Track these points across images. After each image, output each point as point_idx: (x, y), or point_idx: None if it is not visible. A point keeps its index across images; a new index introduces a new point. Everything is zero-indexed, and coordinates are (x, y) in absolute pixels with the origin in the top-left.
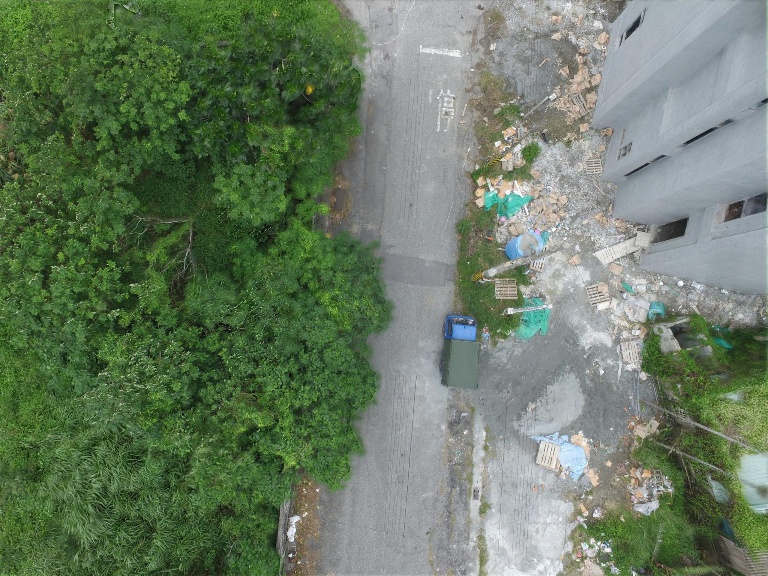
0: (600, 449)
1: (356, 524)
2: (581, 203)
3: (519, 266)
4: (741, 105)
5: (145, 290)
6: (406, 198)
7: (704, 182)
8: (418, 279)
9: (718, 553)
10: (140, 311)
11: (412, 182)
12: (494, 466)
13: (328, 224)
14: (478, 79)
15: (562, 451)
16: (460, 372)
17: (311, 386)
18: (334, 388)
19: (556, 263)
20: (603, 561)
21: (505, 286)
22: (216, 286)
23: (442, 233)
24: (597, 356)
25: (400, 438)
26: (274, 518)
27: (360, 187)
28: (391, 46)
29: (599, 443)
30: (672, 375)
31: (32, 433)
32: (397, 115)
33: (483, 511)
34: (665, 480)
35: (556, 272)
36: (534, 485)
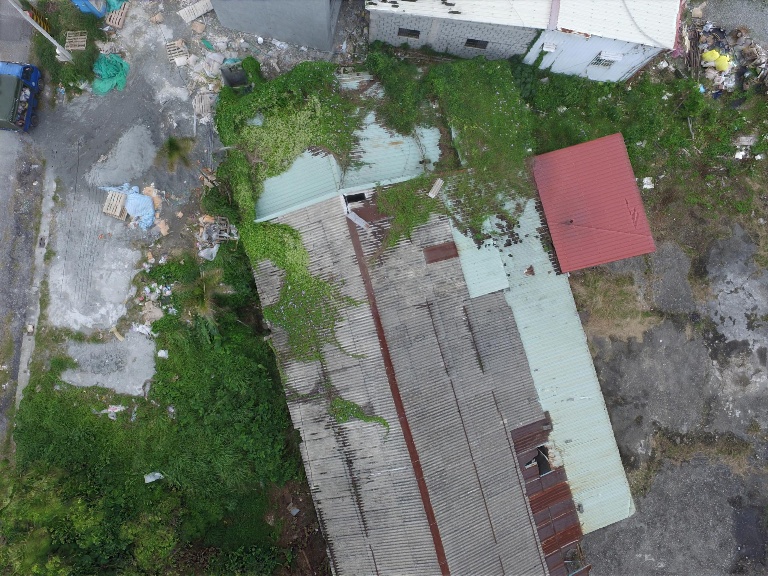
0: (172, 201)
1: None
2: None
3: (85, 15)
4: None
5: None
6: None
7: None
8: None
9: None
10: None
11: None
12: (63, 216)
13: None
14: None
15: (128, 199)
16: None
17: None
18: None
19: (138, 21)
20: (164, 304)
21: (76, 38)
22: None
23: None
24: (172, 110)
25: None
26: None
27: None
28: None
29: (171, 194)
30: None
31: None
32: None
33: (47, 257)
34: (233, 229)
35: (137, 29)
36: (101, 233)
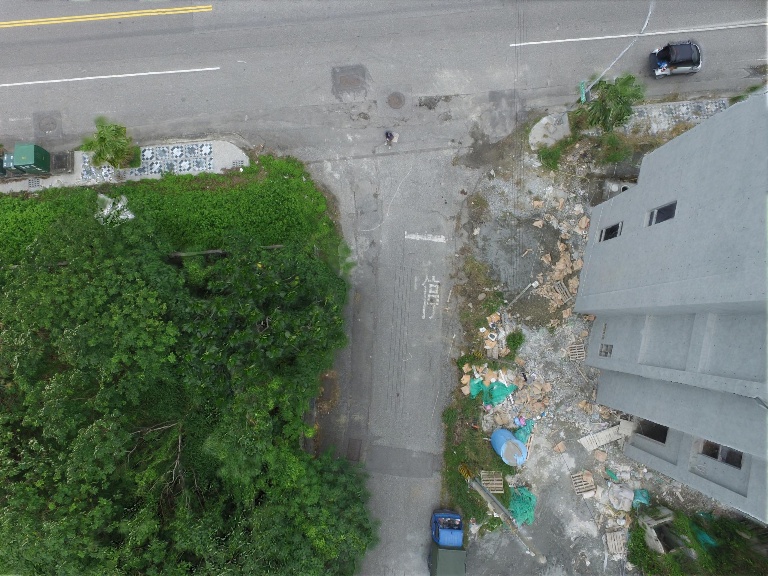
0: None
1: None
2: (565, 390)
3: None
4: None
5: (134, 514)
6: (393, 388)
7: None
8: (405, 471)
9: None
10: (129, 541)
11: (398, 371)
12: None
13: (316, 414)
14: (462, 264)
15: None
16: None
17: None
18: None
19: (541, 451)
20: None
21: (491, 479)
22: (205, 489)
23: (429, 423)
24: (583, 547)
25: None
26: None
27: (347, 376)
28: (376, 232)
29: None
30: (656, 573)
31: None
32: (383, 303)
33: None
34: None
35: (541, 460)
36: None
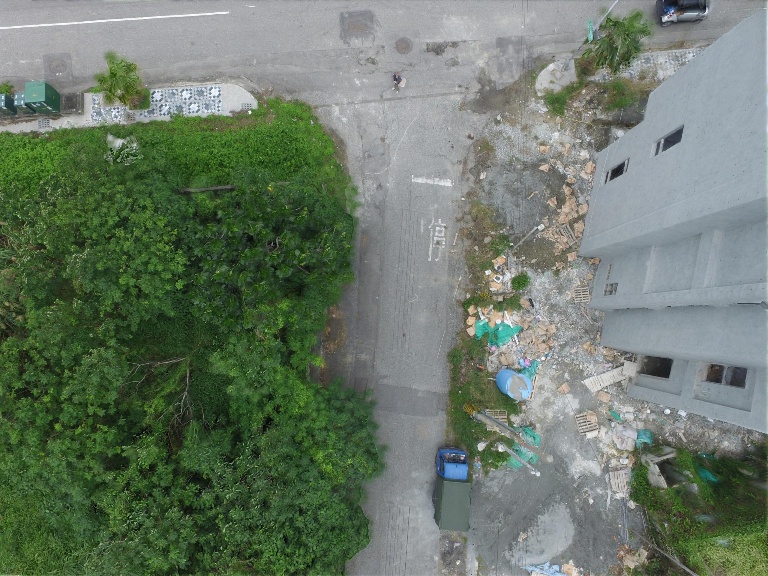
0: None
1: None
2: (570, 332)
3: (509, 399)
4: (718, 301)
5: (143, 441)
6: (399, 328)
7: (686, 353)
8: (411, 409)
9: None
10: (138, 465)
11: (405, 312)
12: None
13: (323, 354)
14: (468, 208)
15: None
16: (452, 514)
17: (306, 550)
18: (328, 547)
19: (546, 391)
20: None
21: (496, 417)
22: (213, 423)
23: (434, 363)
24: (586, 485)
25: (394, 570)
26: None
27: (354, 317)
28: (383, 176)
29: (589, 572)
30: (659, 509)
31: (31, 575)
32: (390, 245)
33: None
34: None
35: (546, 400)
36: None
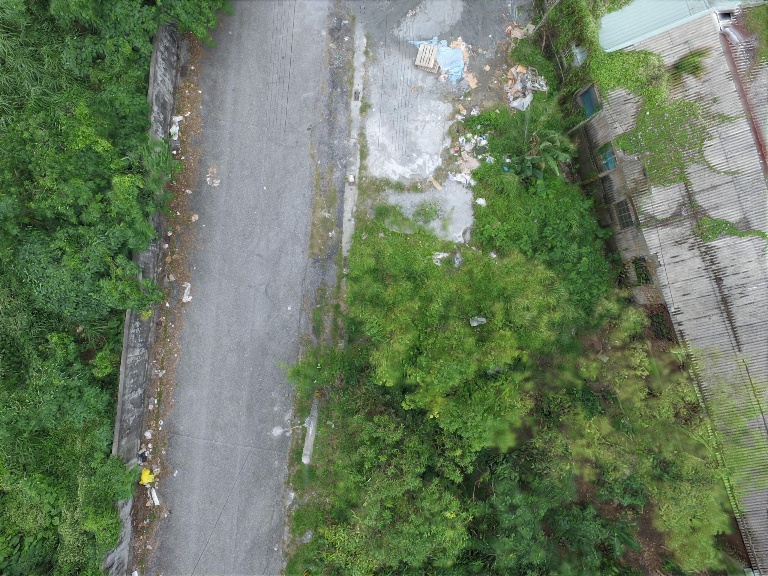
0: (479, 54)
1: (238, 120)
2: None
3: None
4: None
5: None
6: None
7: None
8: None
9: (591, 146)
10: None
11: None
12: (375, 70)
13: None
14: None
15: (440, 52)
16: None
17: None
18: None
19: None
20: (479, 153)
21: None
22: None
23: None
24: None
25: (281, 41)
26: (144, 73)
27: None
28: None
29: (478, 48)
30: None
31: None
32: None
33: (363, 110)
34: (541, 80)
35: None
36: (413, 86)
